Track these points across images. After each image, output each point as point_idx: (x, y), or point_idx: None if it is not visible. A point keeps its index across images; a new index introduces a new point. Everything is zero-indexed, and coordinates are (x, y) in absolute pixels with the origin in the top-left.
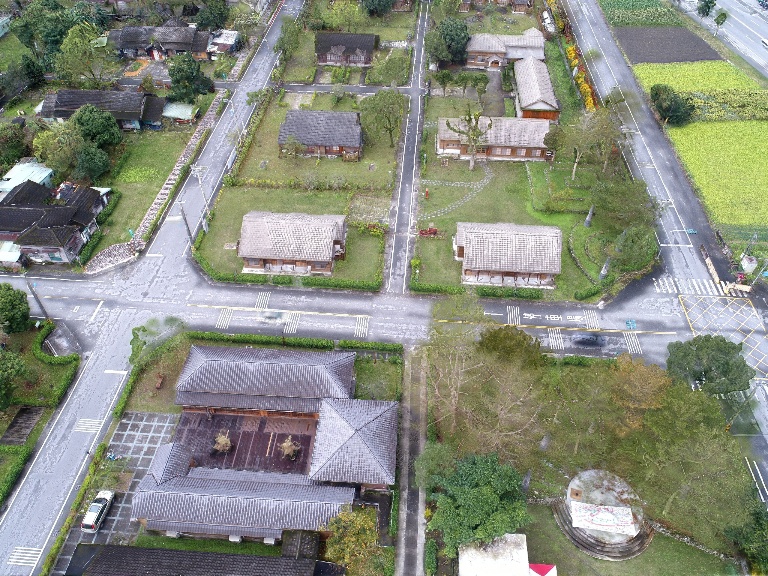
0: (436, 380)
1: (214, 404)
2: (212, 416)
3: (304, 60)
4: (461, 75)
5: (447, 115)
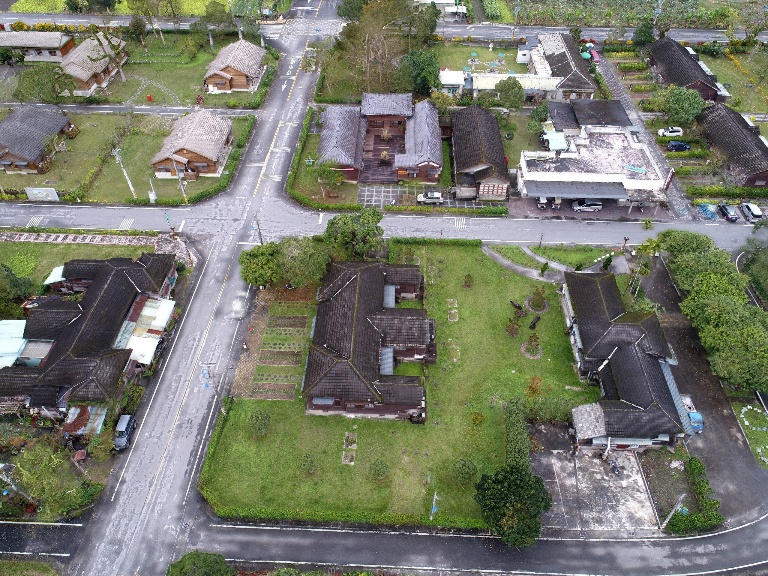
0: None
1: (362, 154)
2: None
3: None
4: None
5: None
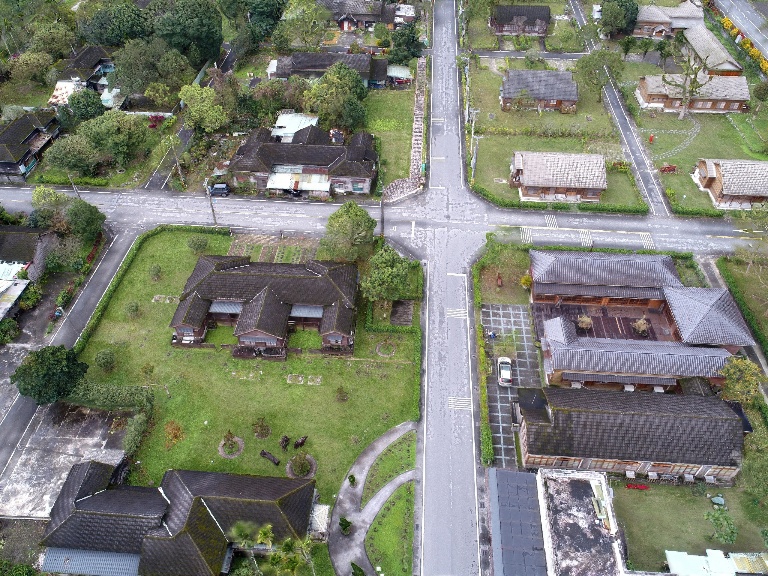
0: (734, 279)
1: (568, 293)
2: (560, 305)
3: (481, 31)
4: (644, 41)
5: (635, 76)
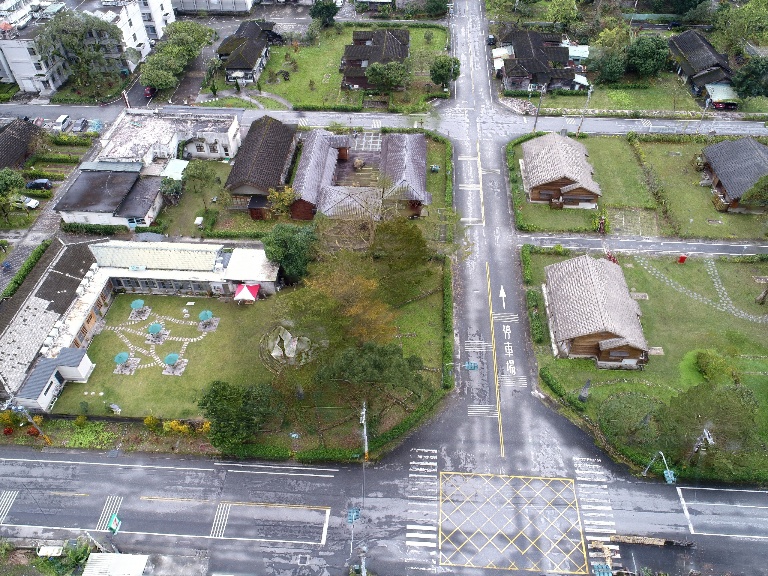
0: None
1: (382, 151)
2: None
3: None
4: None
5: None
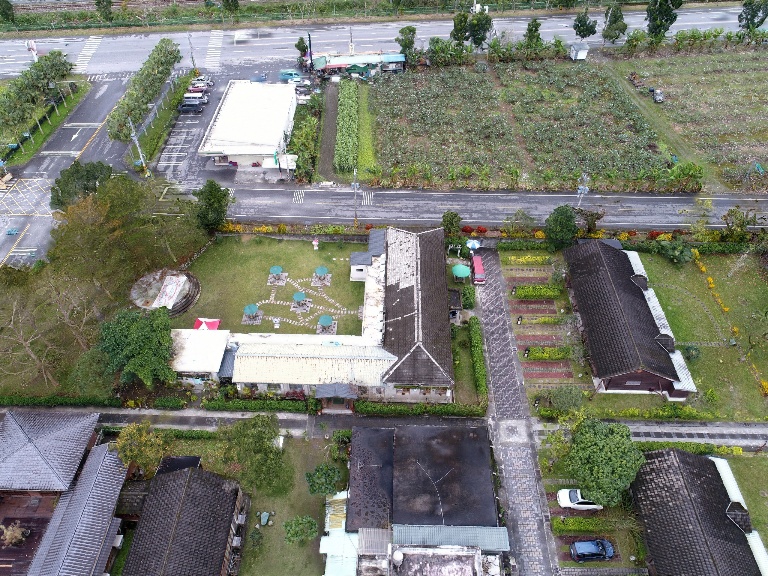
0: None
1: None
2: None
3: None
4: None
5: None
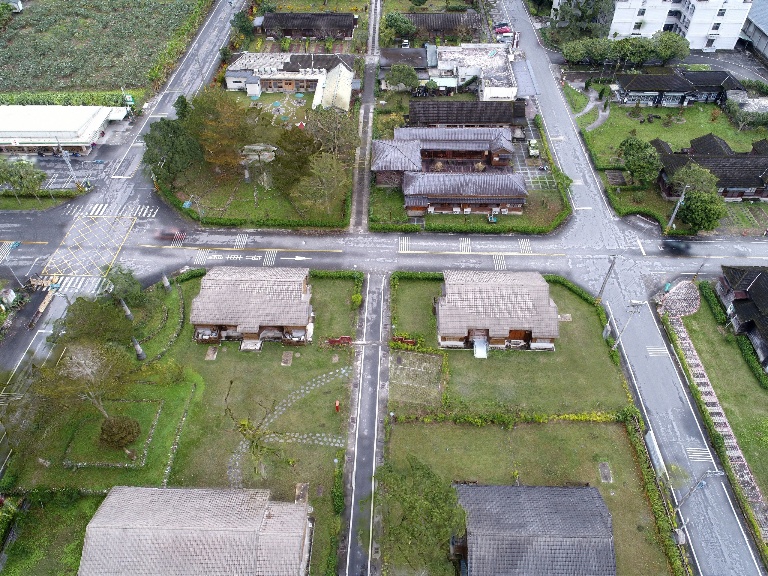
0: None
1: None
2: None
3: None
4: None
5: None
